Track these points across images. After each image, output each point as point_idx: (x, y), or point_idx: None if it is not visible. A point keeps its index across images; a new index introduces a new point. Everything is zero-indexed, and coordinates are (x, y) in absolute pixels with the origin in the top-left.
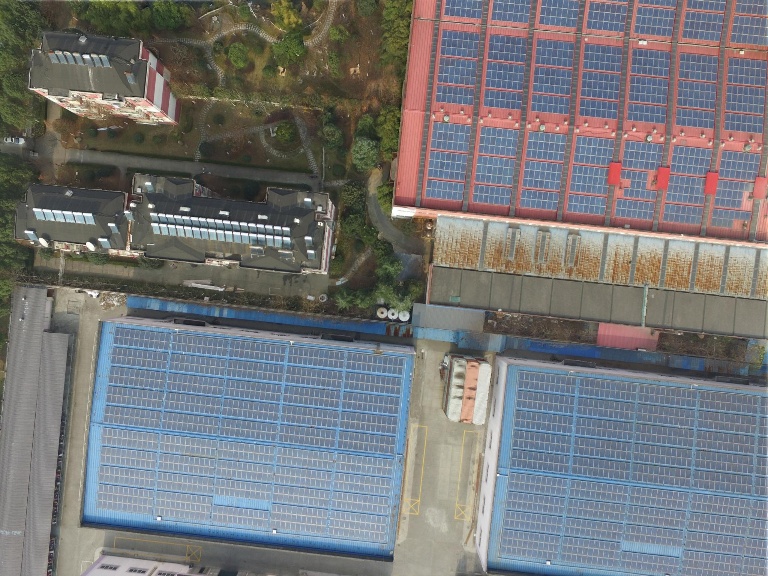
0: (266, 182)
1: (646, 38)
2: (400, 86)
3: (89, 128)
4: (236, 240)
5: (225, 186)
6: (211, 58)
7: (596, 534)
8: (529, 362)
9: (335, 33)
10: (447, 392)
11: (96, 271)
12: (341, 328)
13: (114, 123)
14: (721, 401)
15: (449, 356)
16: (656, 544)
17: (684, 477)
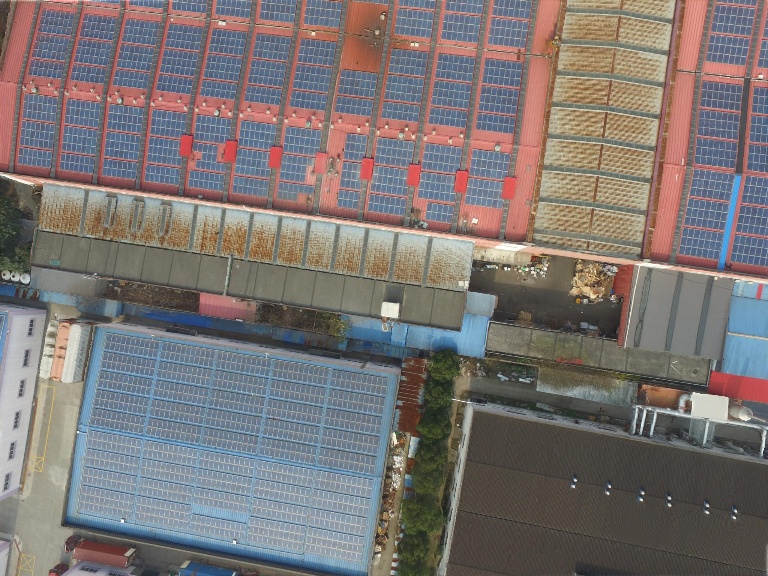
0: None
1: (226, 19)
2: None
3: None
4: None
5: None
6: None
7: (168, 495)
8: None
9: None
10: None
11: None
12: None
13: None
14: (294, 371)
15: None
16: (224, 509)
17: (251, 444)
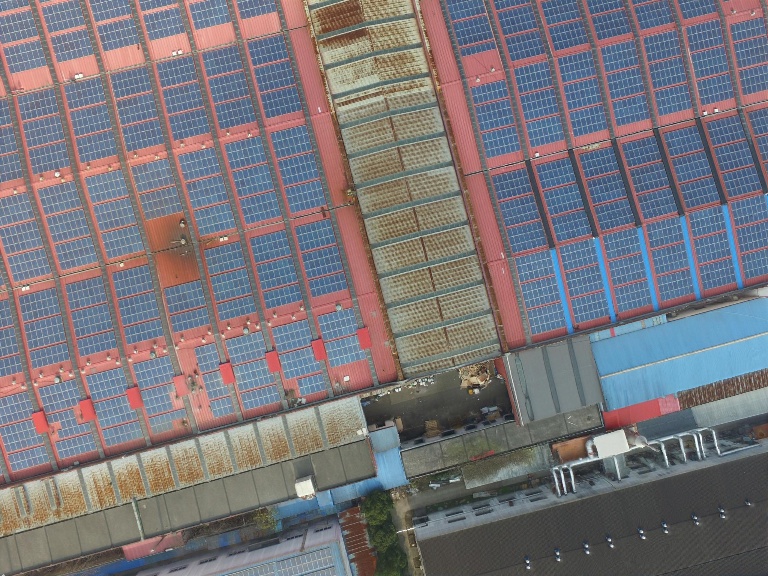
0: None
1: (28, 282)
2: None
3: None
4: None
5: None
6: None
7: None
8: None
9: None
10: None
11: None
12: None
13: None
14: None
15: None
16: None
17: None
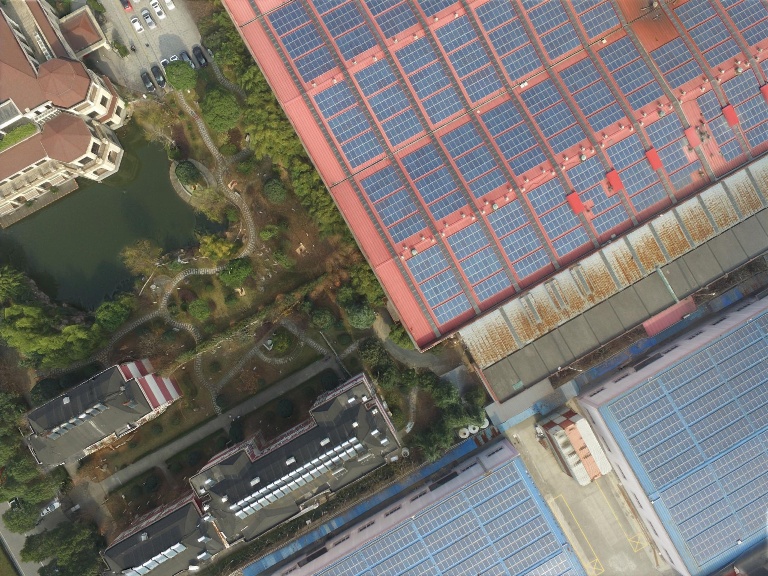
0: (291, 391)
1: (524, 79)
2: (358, 251)
3: (108, 452)
4: (315, 476)
5: (259, 418)
6: (172, 321)
7: (759, 492)
8: (609, 390)
9: (267, 235)
10: (560, 459)
11: (203, 572)
12: (438, 468)
13: (129, 434)
14: None
15: (539, 426)
16: None
17: None
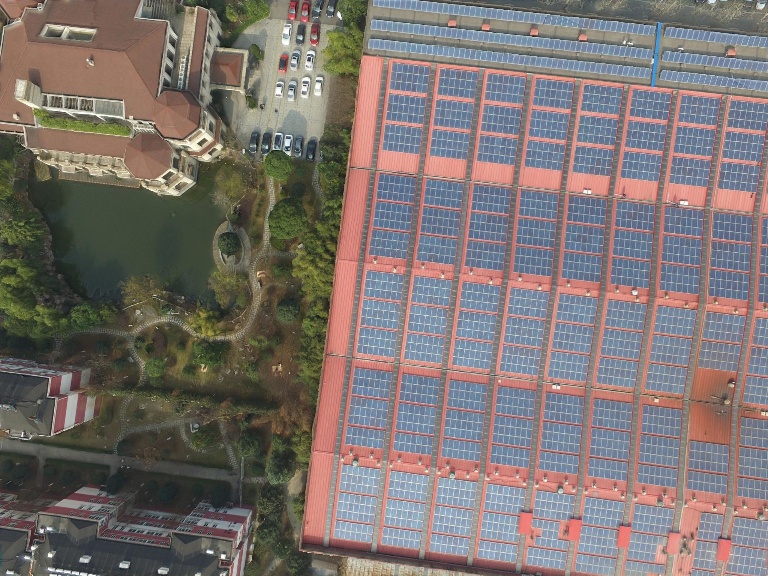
0: (185, 477)
1: (560, 382)
2: (310, 425)
3: None
4: None
5: (143, 480)
6: (134, 350)
7: None
8: None
9: (254, 343)
10: None
11: None
12: None
13: None
14: None
15: None
16: None
17: None
